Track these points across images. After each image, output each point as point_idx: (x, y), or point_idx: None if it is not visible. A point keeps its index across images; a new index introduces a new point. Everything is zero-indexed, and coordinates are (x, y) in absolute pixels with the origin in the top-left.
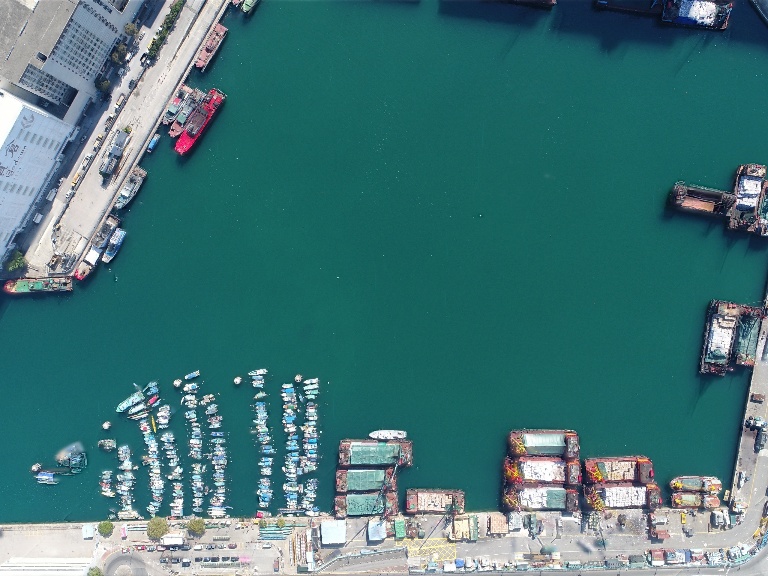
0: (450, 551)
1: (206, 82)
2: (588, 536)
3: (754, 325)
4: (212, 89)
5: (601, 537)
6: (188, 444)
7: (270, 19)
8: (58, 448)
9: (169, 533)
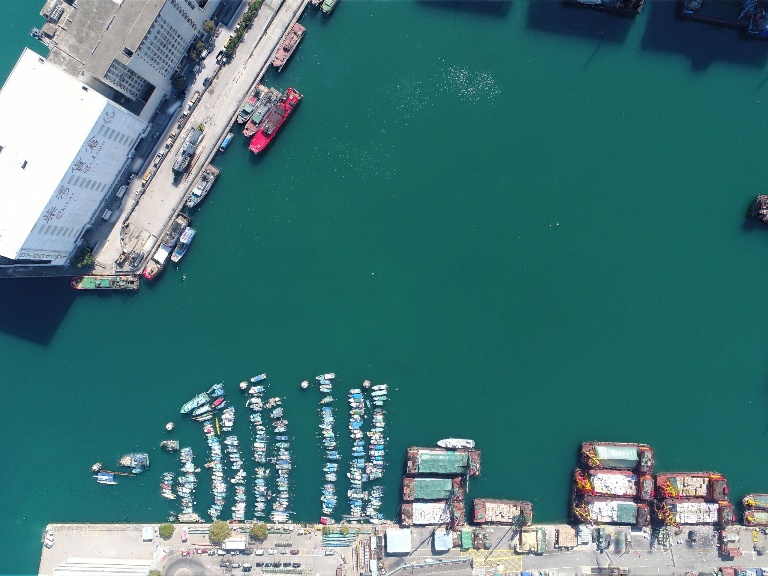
0: (516, 563)
1: (282, 82)
2: (657, 552)
3: None
4: (288, 89)
5: (670, 553)
6: (252, 447)
7: (349, 20)
8: (119, 448)
9: (231, 537)
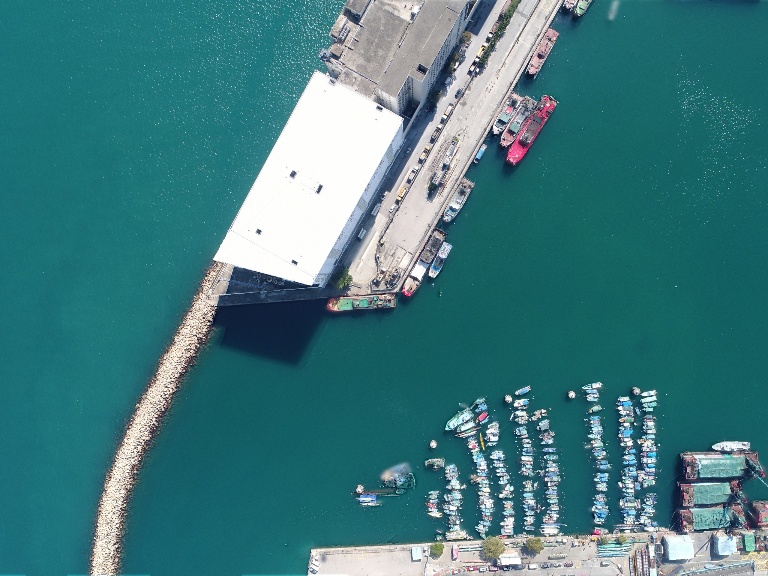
0: None
1: (534, 89)
2: None
3: None
4: (543, 96)
5: None
6: (518, 461)
7: (602, 22)
8: (381, 469)
9: (504, 553)
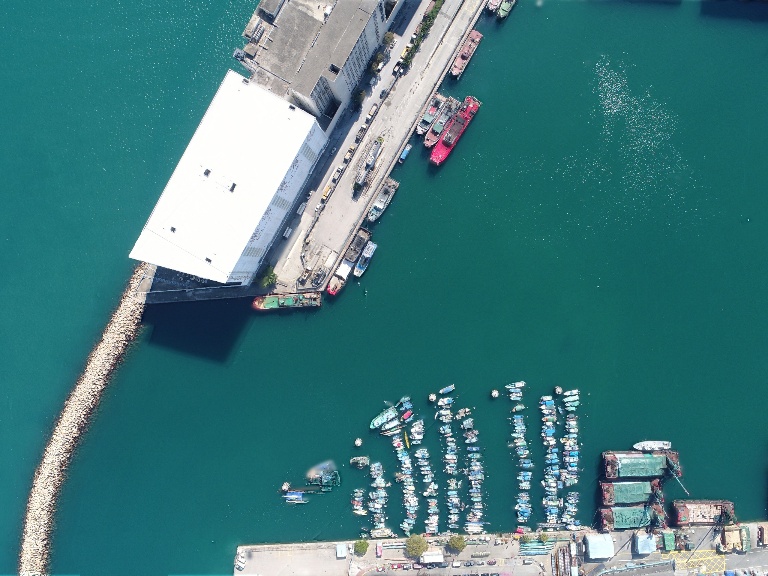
0: (719, 563)
1: (459, 90)
2: None
3: None
4: (467, 97)
5: None
6: (443, 459)
7: (525, 24)
8: (307, 466)
9: (428, 551)
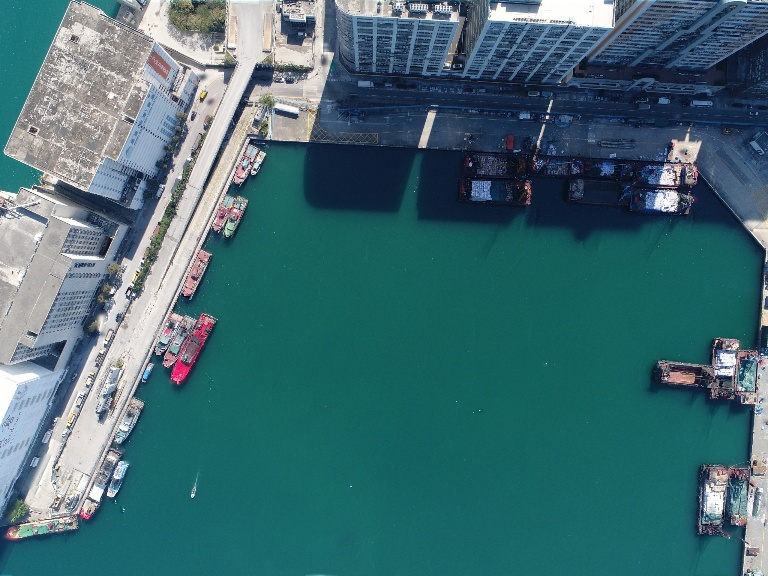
0: None
1: (195, 307)
2: None
3: (743, 486)
4: (202, 315)
5: None
6: None
7: (253, 239)
8: None
9: None
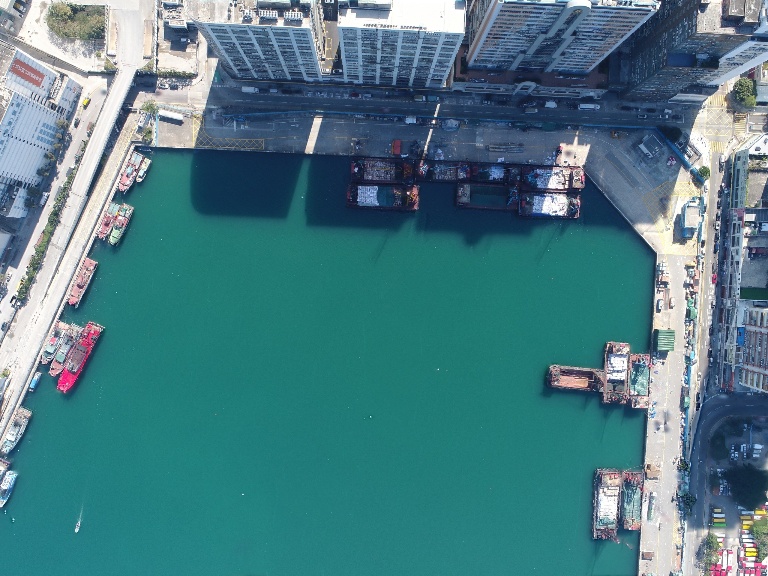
0: None
1: (82, 315)
2: None
3: (636, 490)
4: (89, 323)
5: None
6: None
7: (140, 247)
8: None
9: None
